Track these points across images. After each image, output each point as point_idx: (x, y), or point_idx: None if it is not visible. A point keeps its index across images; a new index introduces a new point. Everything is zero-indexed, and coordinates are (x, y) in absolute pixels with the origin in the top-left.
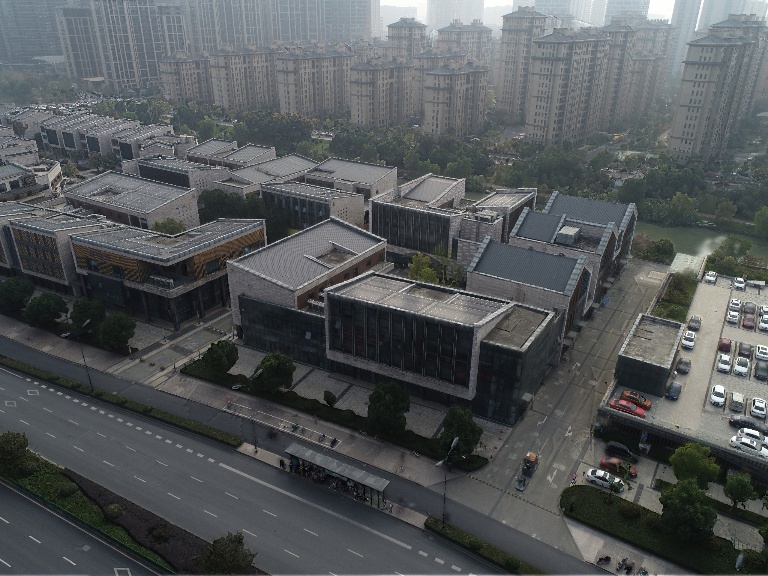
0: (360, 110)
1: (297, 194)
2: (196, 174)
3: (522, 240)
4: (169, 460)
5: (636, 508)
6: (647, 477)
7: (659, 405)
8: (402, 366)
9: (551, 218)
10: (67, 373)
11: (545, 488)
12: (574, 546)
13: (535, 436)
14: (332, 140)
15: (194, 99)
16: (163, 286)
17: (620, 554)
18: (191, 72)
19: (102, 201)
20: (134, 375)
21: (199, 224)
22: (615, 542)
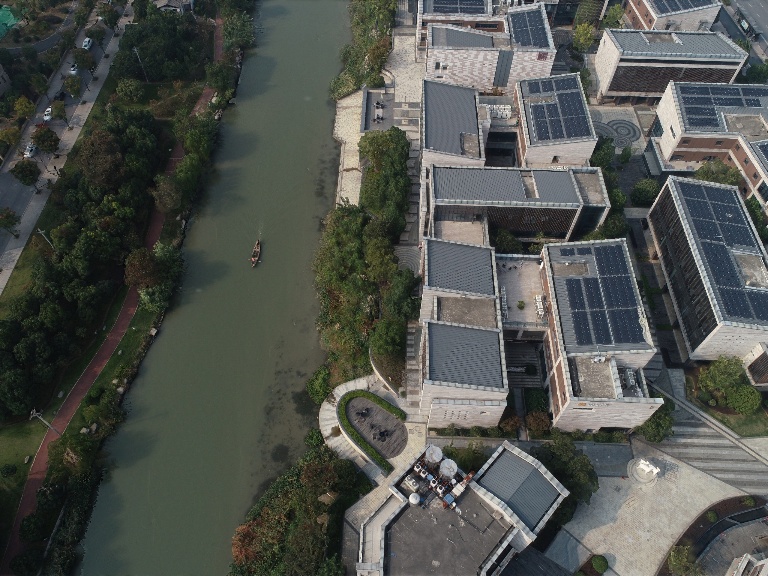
0: None
1: None
2: None
3: None
4: None
5: None
6: None
7: None
8: None
9: None
10: None
11: None
12: None
13: None
14: None
15: None
16: None
17: None
18: None
19: (766, 258)
20: None
21: None
22: None
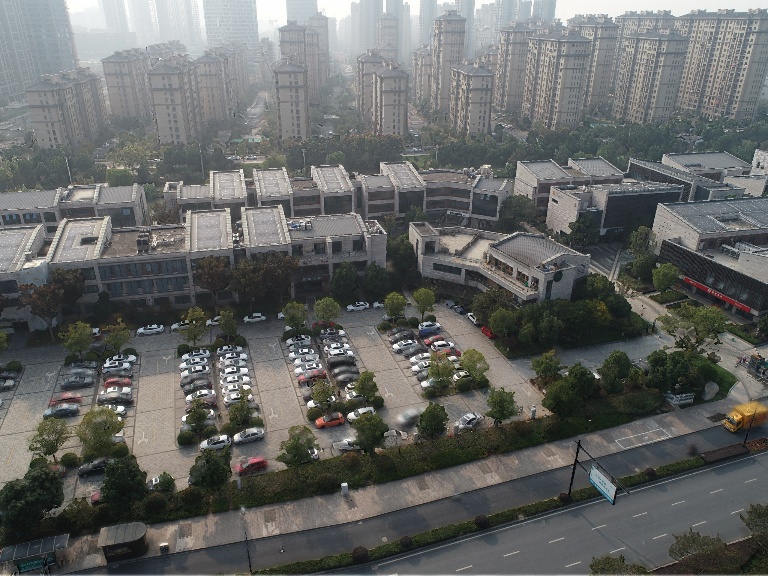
0: (397, 120)
1: None
2: None
3: None
4: None
5: None
6: None
7: None
8: None
9: None
10: None
11: None
12: None
13: None
14: (434, 154)
15: (82, 141)
16: None
17: None
18: (73, 102)
19: (759, 227)
20: None
21: None
22: None
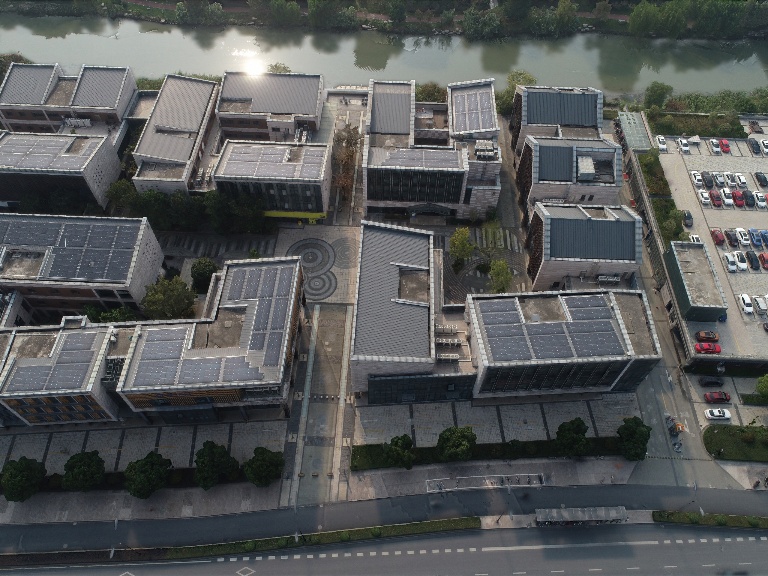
0: None
1: (272, 180)
2: (89, 169)
3: (546, 184)
4: (444, 570)
5: (753, 434)
6: (734, 395)
7: (720, 332)
8: (552, 388)
9: (563, 151)
10: (247, 530)
11: (690, 441)
12: (735, 481)
13: (653, 393)
14: None
15: None
16: (267, 393)
17: (759, 473)
18: None
19: (33, 281)
20: (313, 497)
21: (160, 248)
22: (752, 465)
